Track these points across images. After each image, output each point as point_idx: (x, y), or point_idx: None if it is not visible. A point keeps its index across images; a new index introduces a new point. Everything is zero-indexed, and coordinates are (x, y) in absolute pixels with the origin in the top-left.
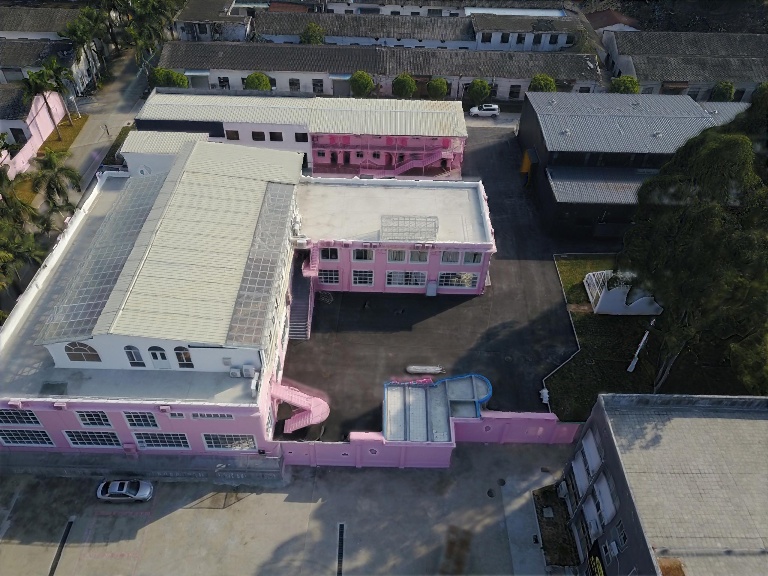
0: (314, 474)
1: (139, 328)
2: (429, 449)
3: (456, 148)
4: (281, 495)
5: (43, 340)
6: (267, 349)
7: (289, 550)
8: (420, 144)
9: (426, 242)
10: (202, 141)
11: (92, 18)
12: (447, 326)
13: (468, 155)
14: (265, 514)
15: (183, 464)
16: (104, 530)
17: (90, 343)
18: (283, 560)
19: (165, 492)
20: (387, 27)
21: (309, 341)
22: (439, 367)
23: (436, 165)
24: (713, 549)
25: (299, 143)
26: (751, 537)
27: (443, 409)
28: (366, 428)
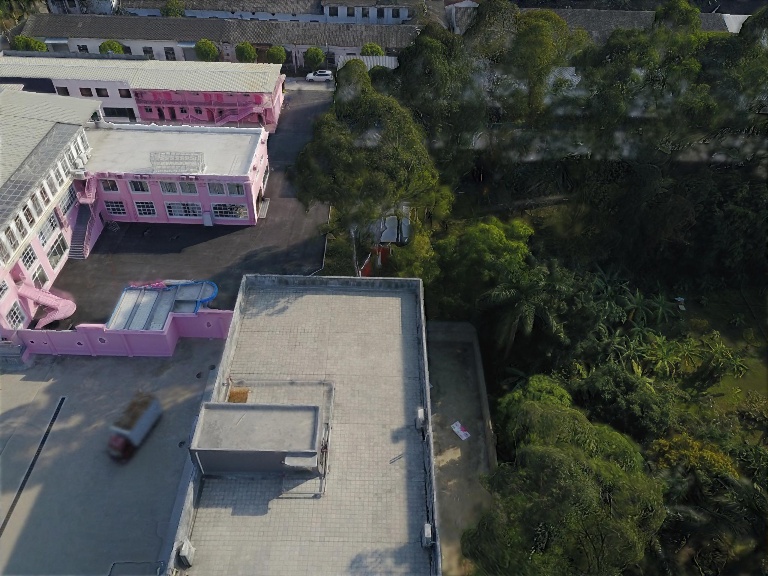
0: (54, 361)
1: None
2: (145, 337)
3: (266, 104)
4: (19, 376)
5: None
6: (7, 251)
7: (11, 415)
8: (235, 100)
9: (190, 174)
10: (10, 90)
11: None
12: (213, 249)
13: (289, 113)
14: None
15: None
16: None
17: None
18: (3, 422)
19: None
20: (243, 2)
21: (86, 260)
22: (192, 280)
23: (254, 120)
24: (280, 381)
25: (124, 99)
26: (318, 374)
27: (168, 307)
28: None
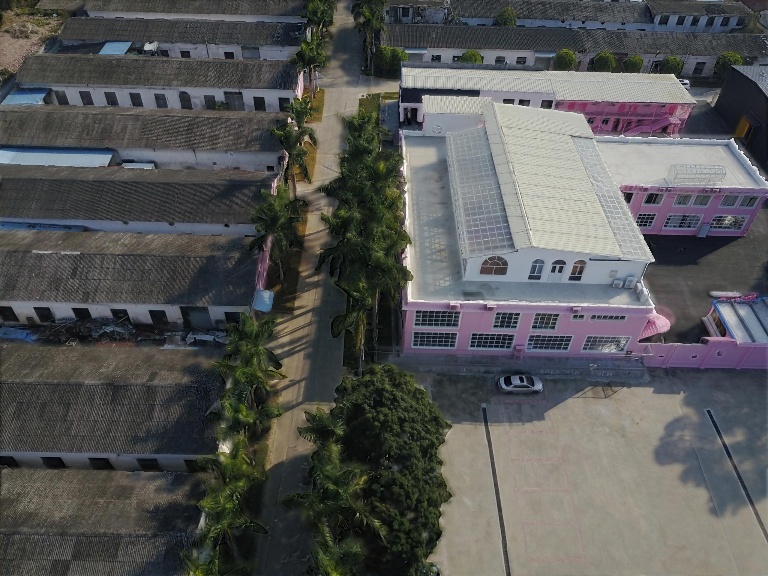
0: (667, 373)
1: (552, 243)
2: None
3: (682, 114)
4: (648, 388)
5: (470, 254)
6: None
7: (675, 428)
8: (649, 111)
9: (714, 187)
10: None
11: (322, 1)
12: (726, 261)
13: None
14: (642, 402)
15: (562, 363)
16: (515, 413)
17: (509, 256)
18: (674, 435)
19: (551, 386)
20: (571, 11)
21: None
22: (736, 292)
23: None
24: None
25: None
26: None
27: None
28: (698, 338)
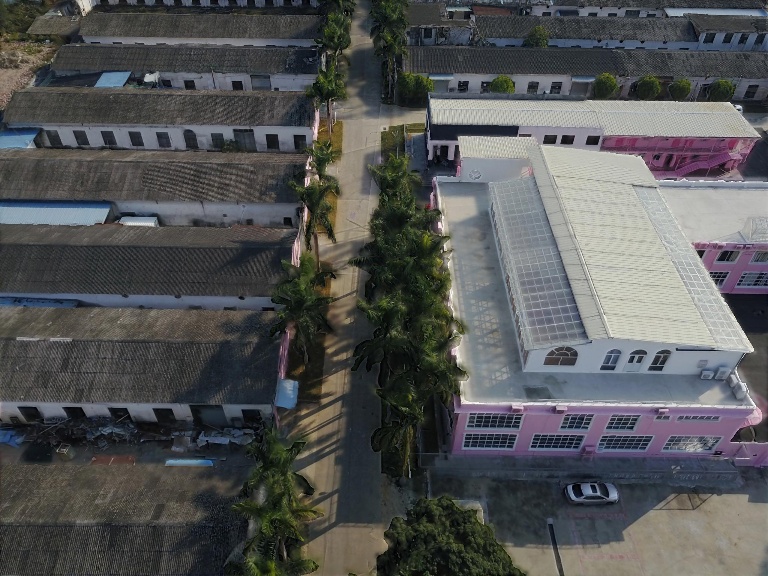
0: (762, 475)
1: (632, 332)
2: None
3: (743, 149)
4: (742, 496)
5: (533, 345)
6: None
7: None
8: (706, 145)
9: None
10: None
11: (338, 24)
12: None
13: None
14: (737, 515)
15: (639, 466)
16: (588, 532)
17: (580, 347)
18: None
19: (627, 494)
20: (608, 29)
21: None
22: None
23: None
24: None
25: (588, 146)
26: None
27: None
28: None
